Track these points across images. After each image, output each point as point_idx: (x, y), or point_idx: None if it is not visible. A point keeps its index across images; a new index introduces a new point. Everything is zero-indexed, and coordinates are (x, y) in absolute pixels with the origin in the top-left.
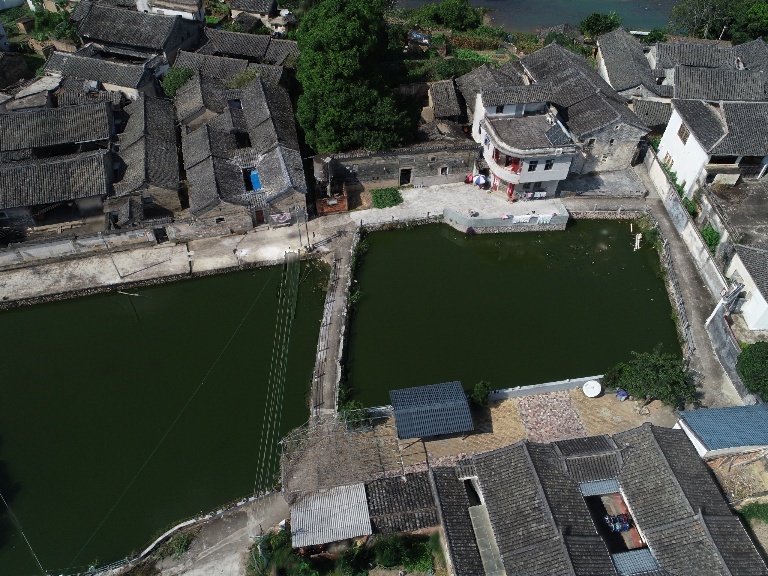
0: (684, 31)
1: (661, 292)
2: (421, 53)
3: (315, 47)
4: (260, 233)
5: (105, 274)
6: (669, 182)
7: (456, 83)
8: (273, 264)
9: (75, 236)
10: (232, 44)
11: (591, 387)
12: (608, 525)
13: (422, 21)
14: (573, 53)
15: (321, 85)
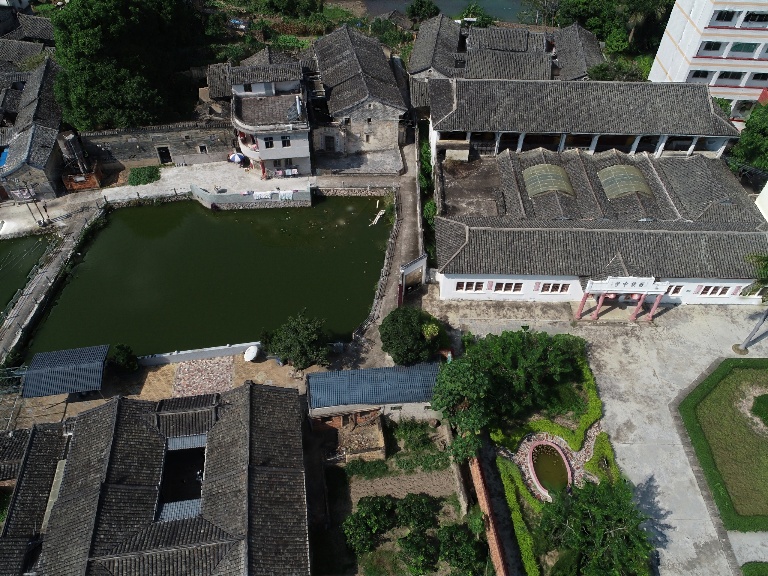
0: (540, 19)
1: (382, 265)
2: (237, 38)
3: (59, 27)
4: (4, 209)
5: None
6: (417, 159)
7: (240, 65)
8: (6, 238)
9: None
10: (42, 29)
11: (252, 352)
12: (196, 479)
13: (259, 9)
14: (367, 36)
15: (67, 64)
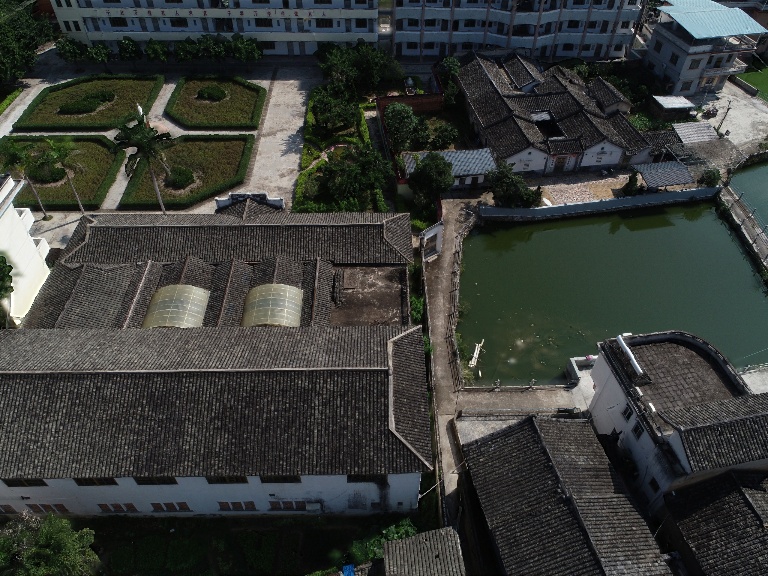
0: None
1: None
2: None
3: None
4: None
5: None
6: None
7: None
8: None
9: None
10: None
11: None
12: None
13: None
14: None
15: None
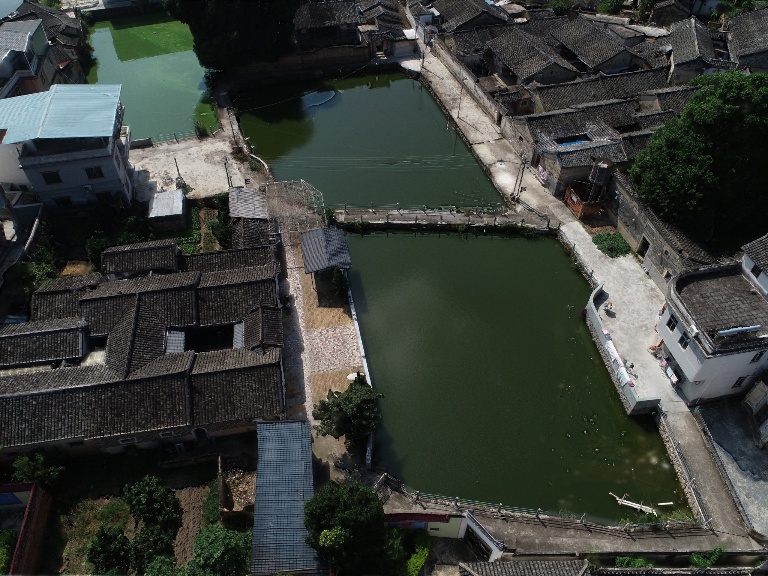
0: None
1: None
2: None
3: None
4: (527, 171)
5: (460, 111)
6: None
7: None
8: (495, 185)
9: (477, 81)
10: None
11: None
12: None
13: None
14: None
15: None
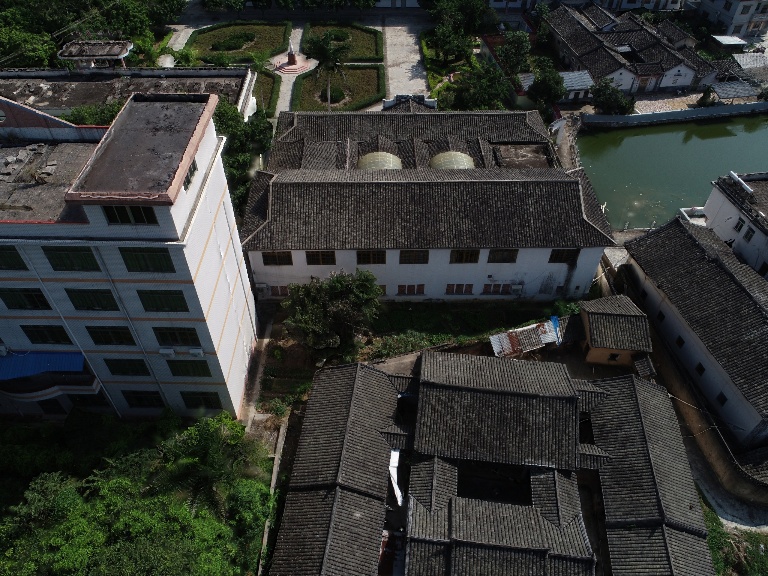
0: None
1: None
2: None
3: None
4: None
5: None
6: None
7: None
8: None
9: None
10: None
11: None
12: None
13: None
14: None
15: None
